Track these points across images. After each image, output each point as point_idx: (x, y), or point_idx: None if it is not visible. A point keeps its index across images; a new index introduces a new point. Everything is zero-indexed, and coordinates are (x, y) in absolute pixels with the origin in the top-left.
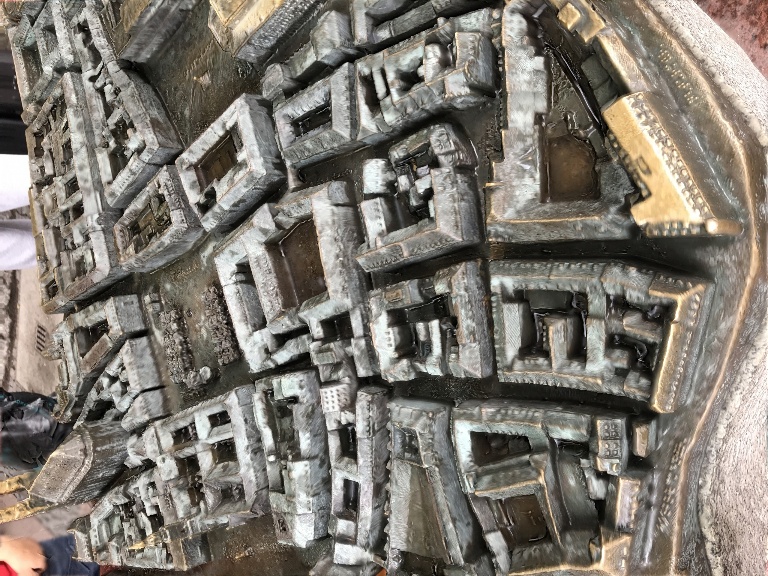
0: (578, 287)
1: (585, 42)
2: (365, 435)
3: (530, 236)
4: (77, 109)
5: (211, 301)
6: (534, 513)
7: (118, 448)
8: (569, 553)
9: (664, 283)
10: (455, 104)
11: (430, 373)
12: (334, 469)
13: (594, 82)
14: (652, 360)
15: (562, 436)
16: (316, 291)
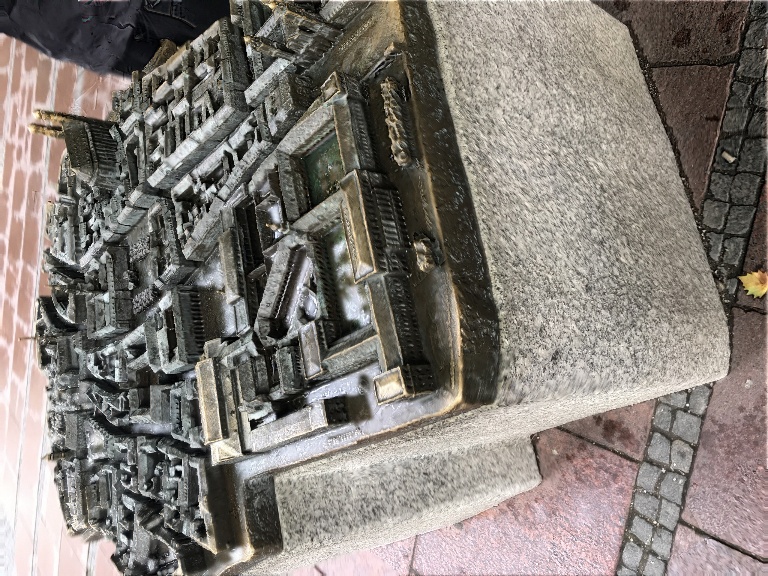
0: None
1: None
2: None
3: None
4: (216, 127)
5: (149, 295)
6: None
7: (108, 189)
8: (92, 511)
9: (129, 573)
10: None
11: None
12: None
13: (169, 571)
14: (122, 558)
15: None
16: (153, 383)
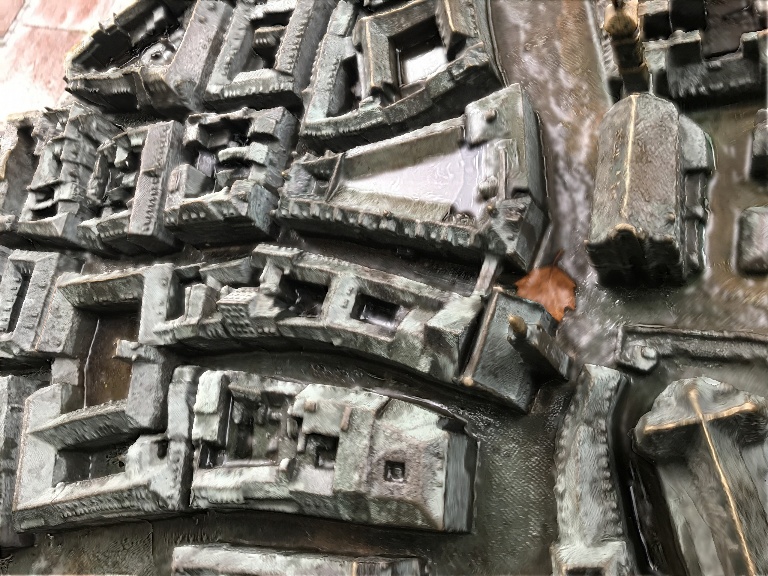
0: (242, 24)
1: (114, 25)
2: (295, 252)
3: (197, 64)
4: None
5: None
6: (427, 66)
7: None
8: None
9: None
10: (98, 138)
11: (261, 160)
12: (326, 320)
13: None
14: None
15: (344, 24)
16: None
